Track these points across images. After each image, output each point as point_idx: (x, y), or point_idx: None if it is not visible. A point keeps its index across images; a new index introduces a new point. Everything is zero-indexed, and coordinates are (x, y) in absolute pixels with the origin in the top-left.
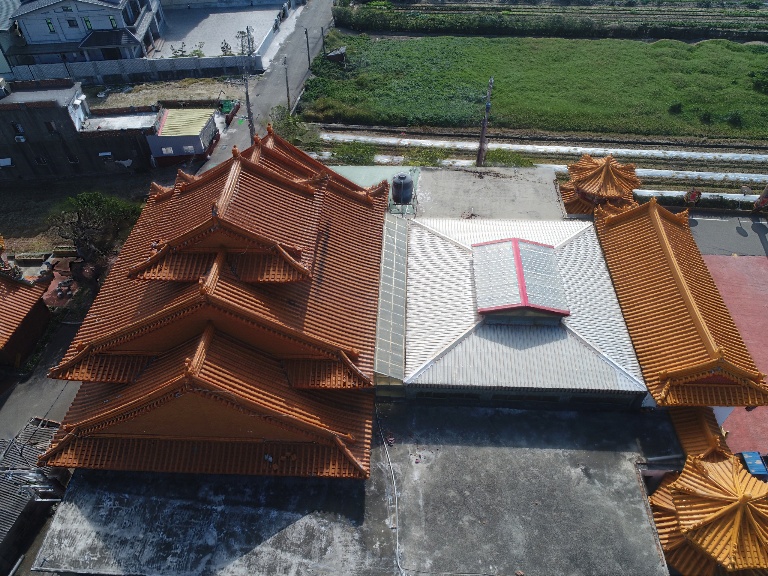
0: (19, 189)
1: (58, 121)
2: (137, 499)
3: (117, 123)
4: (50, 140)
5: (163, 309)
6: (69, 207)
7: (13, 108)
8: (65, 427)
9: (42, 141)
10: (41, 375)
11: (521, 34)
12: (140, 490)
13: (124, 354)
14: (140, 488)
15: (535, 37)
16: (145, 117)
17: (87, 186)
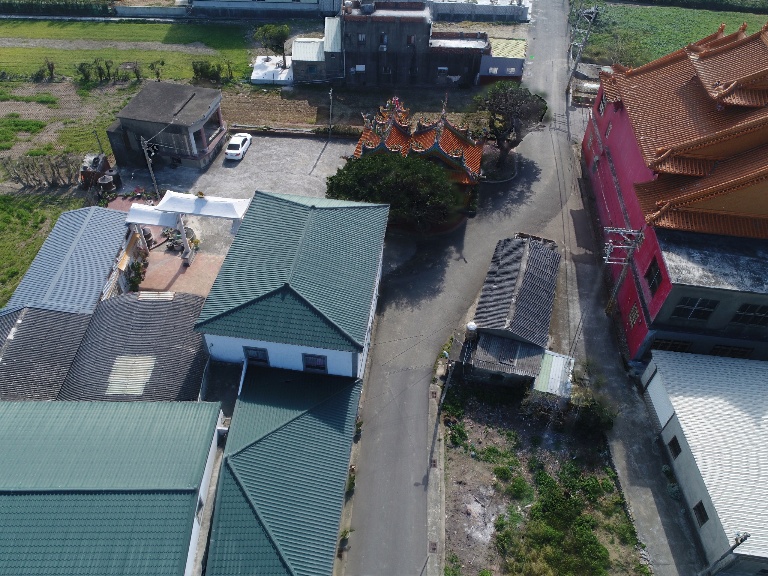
0: (365, 92)
1: (419, 35)
2: (716, 254)
3: (452, 44)
4: (404, 52)
5: (739, 124)
6: (416, 108)
7: (389, 20)
8: (658, 203)
9: (398, 52)
10: (484, 214)
11: (738, 11)
12: (714, 249)
13: (695, 158)
14: (713, 248)
15: (755, 14)
16: (473, 42)
17: (422, 95)
